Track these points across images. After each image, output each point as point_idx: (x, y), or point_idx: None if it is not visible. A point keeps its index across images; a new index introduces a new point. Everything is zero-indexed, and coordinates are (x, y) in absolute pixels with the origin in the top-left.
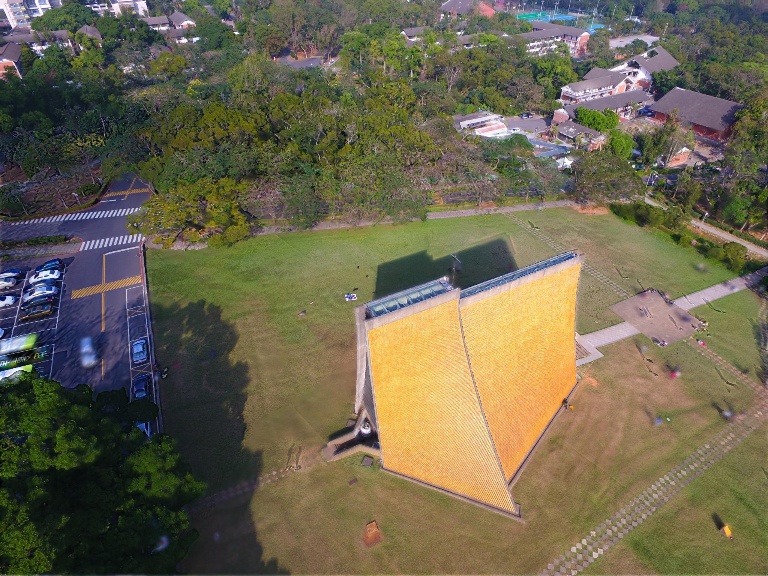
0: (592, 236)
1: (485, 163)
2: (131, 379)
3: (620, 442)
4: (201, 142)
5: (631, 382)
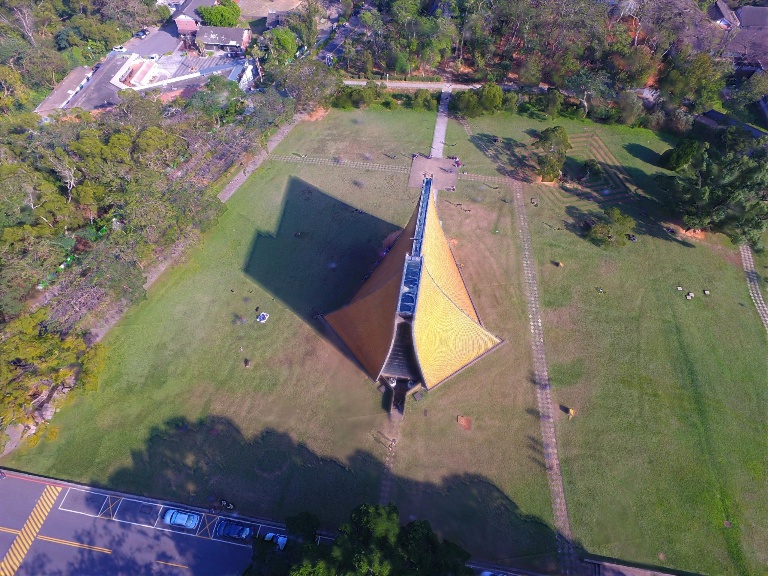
0: (343, 137)
1: None
2: (210, 539)
3: (496, 263)
4: None
5: (466, 225)
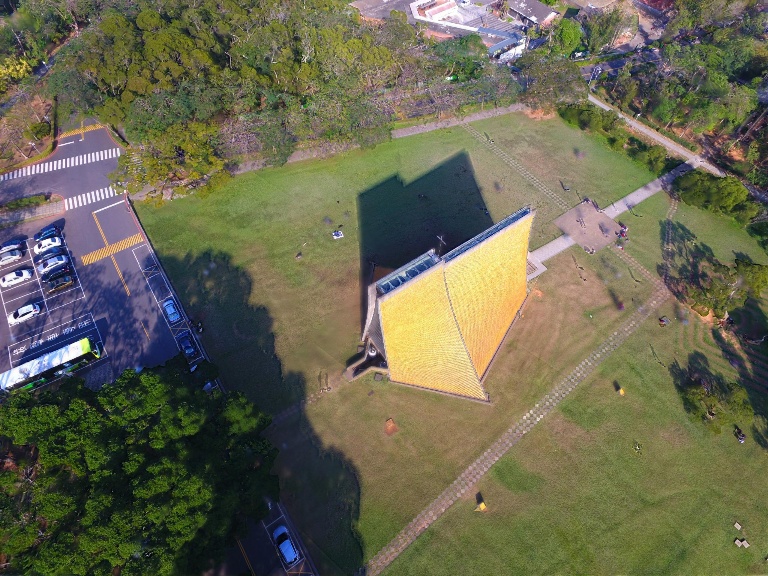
0: (540, 146)
1: (442, 69)
2: (174, 337)
3: (557, 339)
4: (160, 84)
5: (567, 289)
